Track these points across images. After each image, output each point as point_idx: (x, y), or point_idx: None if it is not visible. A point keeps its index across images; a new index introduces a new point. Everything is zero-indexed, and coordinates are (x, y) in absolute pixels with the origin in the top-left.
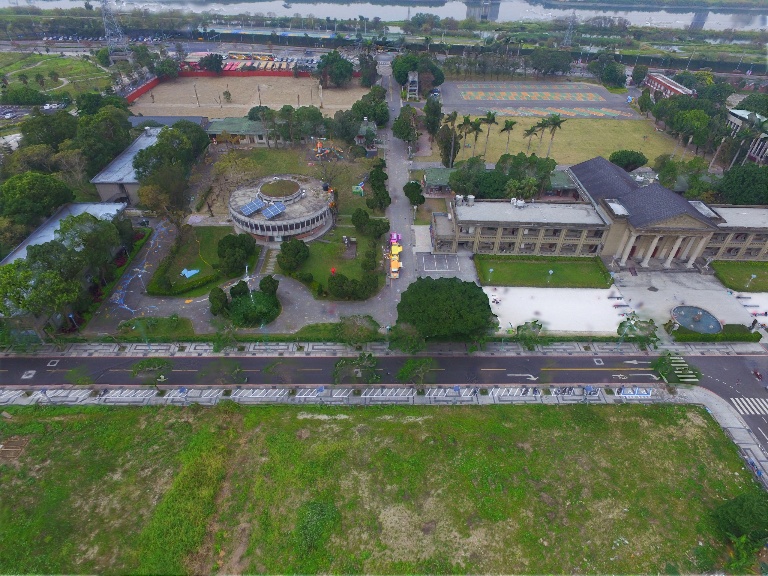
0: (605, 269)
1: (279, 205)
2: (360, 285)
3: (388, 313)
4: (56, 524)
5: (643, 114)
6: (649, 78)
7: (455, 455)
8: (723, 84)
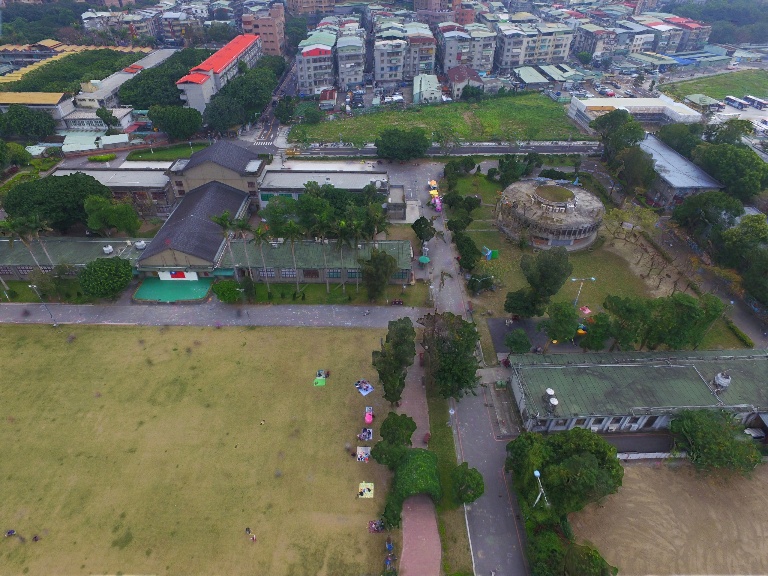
0: None
1: (540, 179)
2: (454, 160)
3: (434, 169)
4: (527, 123)
5: None
6: None
7: None
8: None
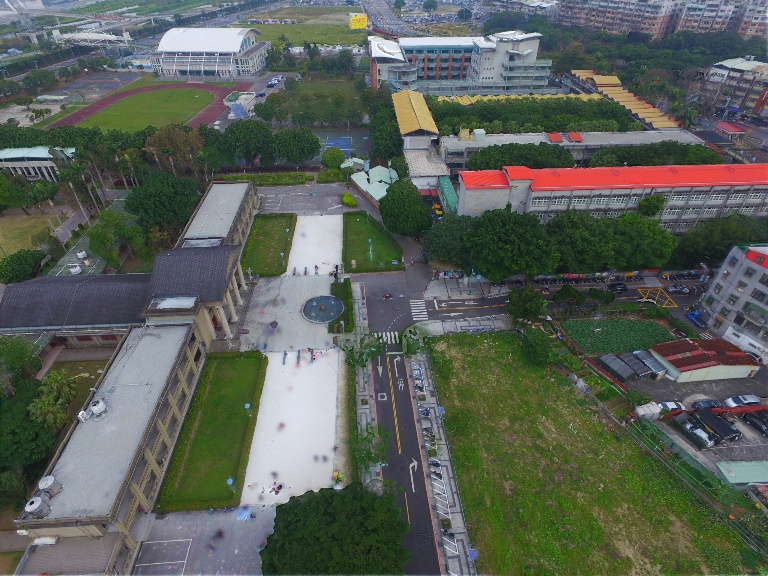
0: (237, 353)
1: None
2: None
3: None
4: None
5: None
6: None
7: (546, 568)
8: None
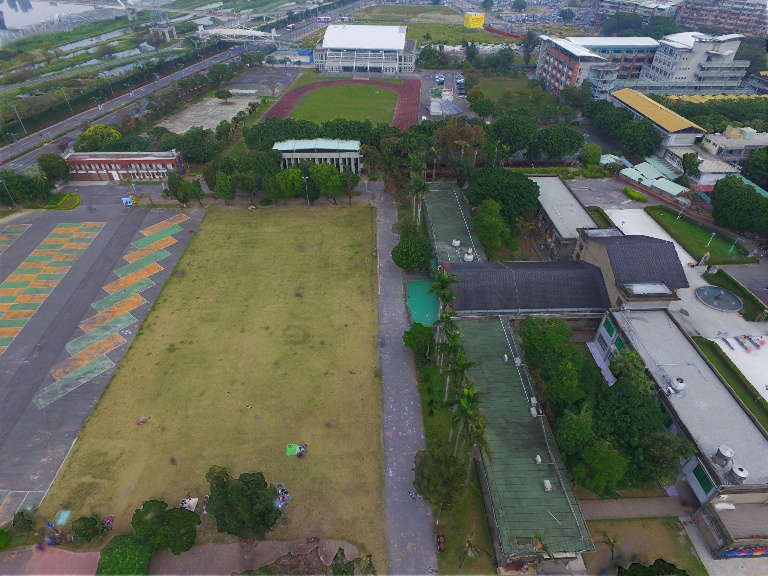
0: None
1: None
2: None
3: None
4: None
5: (187, 205)
6: (73, 165)
7: None
8: (200, 129)
